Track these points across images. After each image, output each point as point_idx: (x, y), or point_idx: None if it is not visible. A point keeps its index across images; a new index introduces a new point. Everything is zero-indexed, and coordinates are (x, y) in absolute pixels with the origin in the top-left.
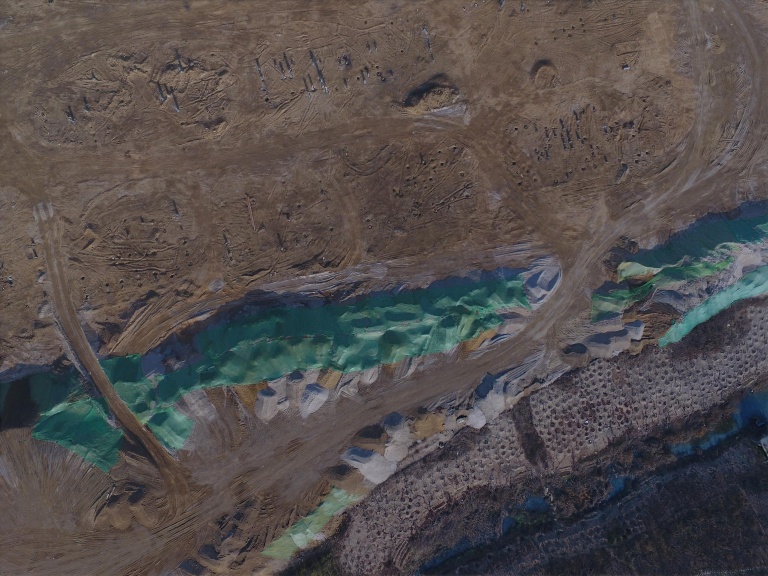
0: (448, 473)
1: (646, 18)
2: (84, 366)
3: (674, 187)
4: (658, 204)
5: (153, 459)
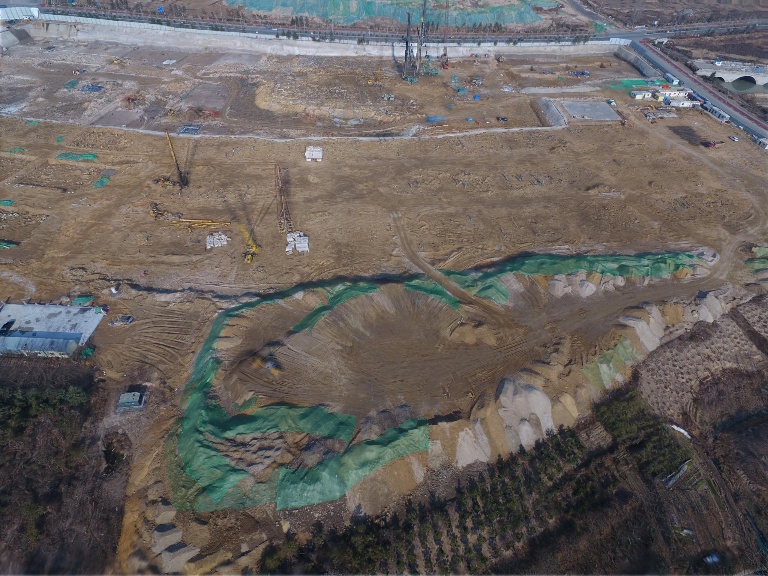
0: (702, 352)
1: (697, 172)
2: (425, 272)
3: (760, 225)
4: (756, 231)
5: None
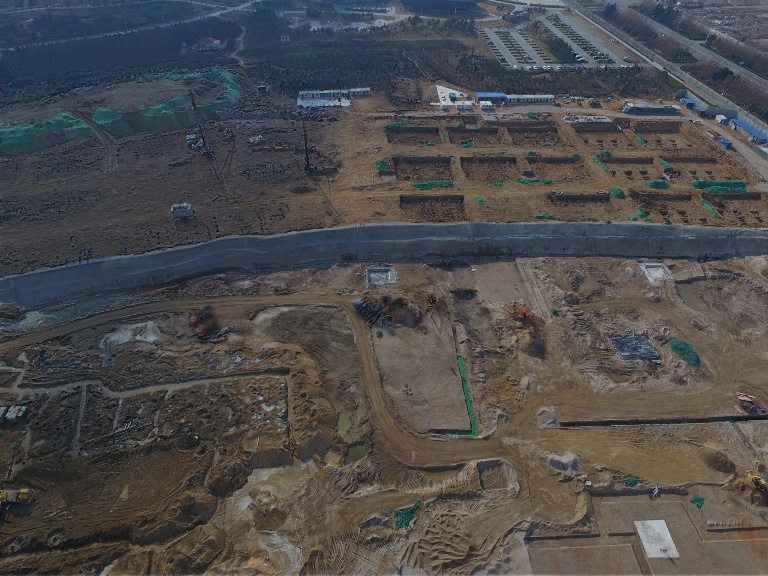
0: None
1: None
2: None
3: None
4: None
5: (78, 113)
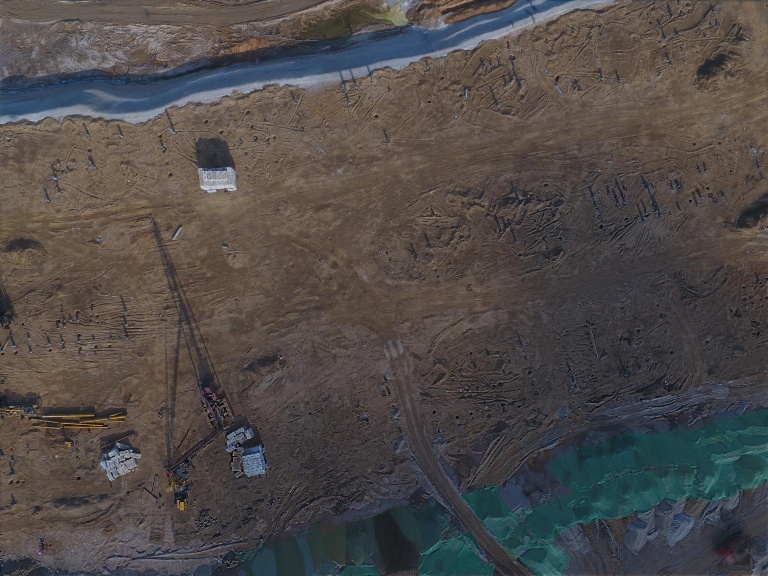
0: None
1: None
2: (446, 500)
3: None
4: None
5: None
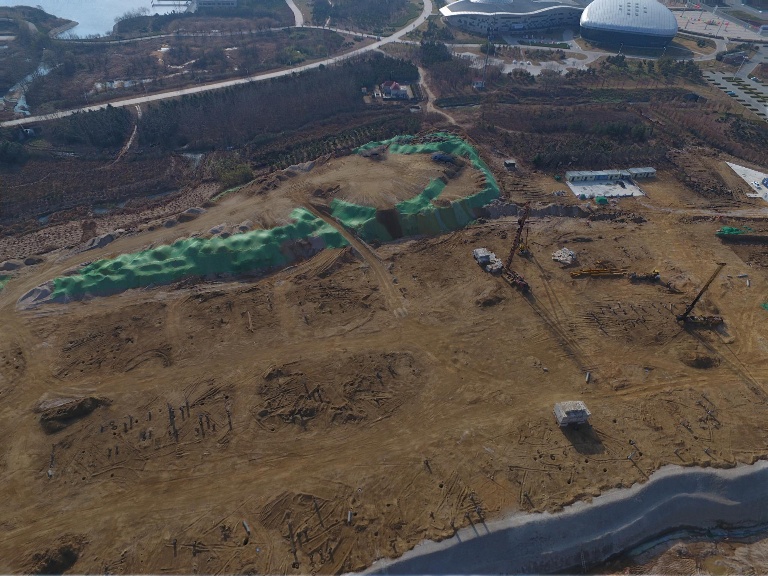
0: None
1: None
2: (359, 242)
3: None
4: None
5: (313, 206)
